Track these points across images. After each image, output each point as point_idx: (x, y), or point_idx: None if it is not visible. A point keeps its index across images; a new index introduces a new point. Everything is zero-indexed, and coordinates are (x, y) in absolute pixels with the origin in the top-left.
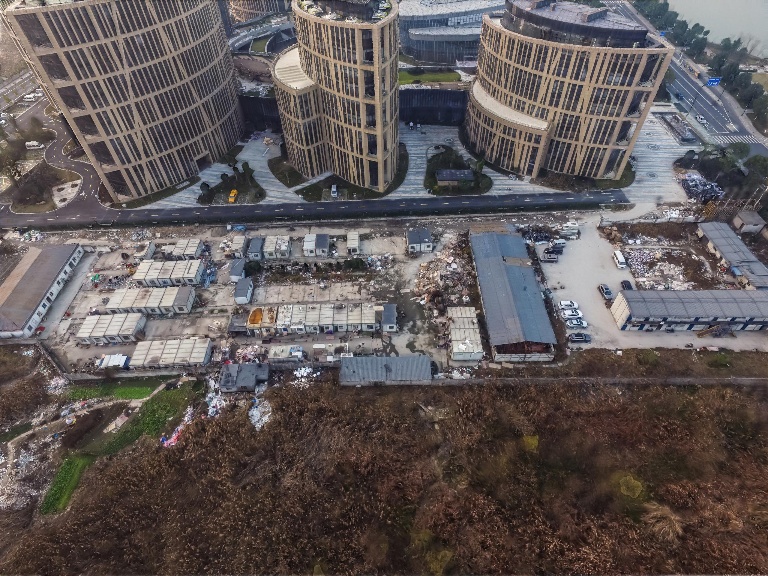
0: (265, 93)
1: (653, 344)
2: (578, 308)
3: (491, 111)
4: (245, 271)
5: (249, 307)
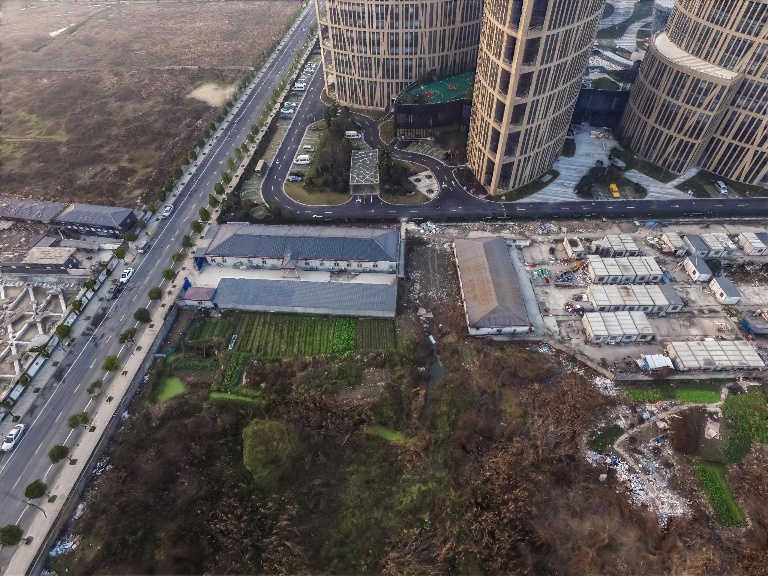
0: (591, 85)
1: None
2: None
3: None
4: None
5: (738, 308)
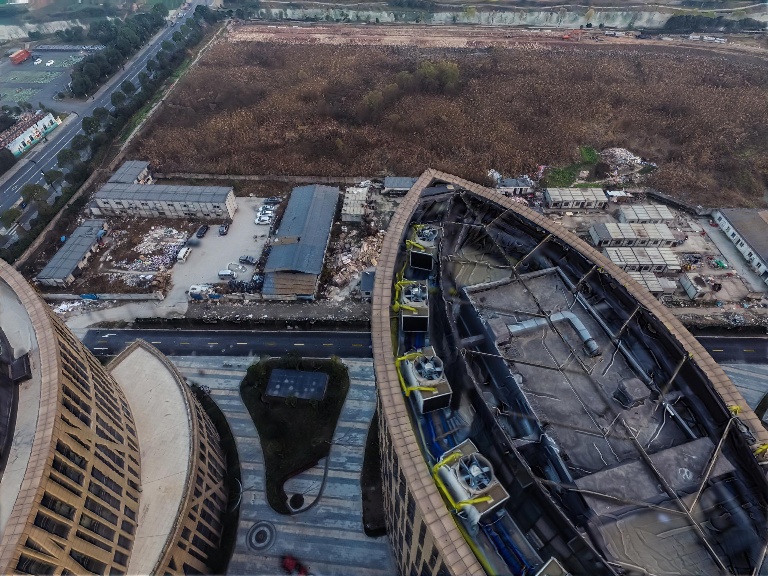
0: None
1: None
2: None
3: None
4: None
5: None
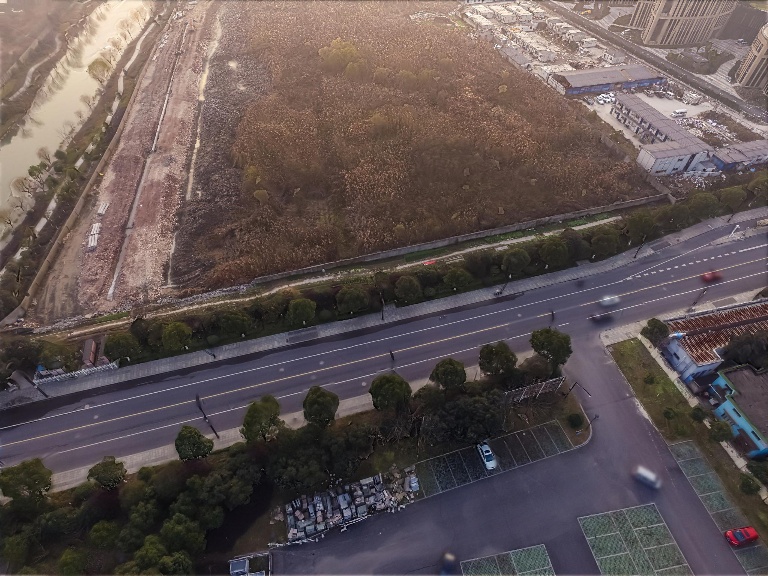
0: None
1: (609, 122)
2: None
3: (766, 24)
4: None
5: None
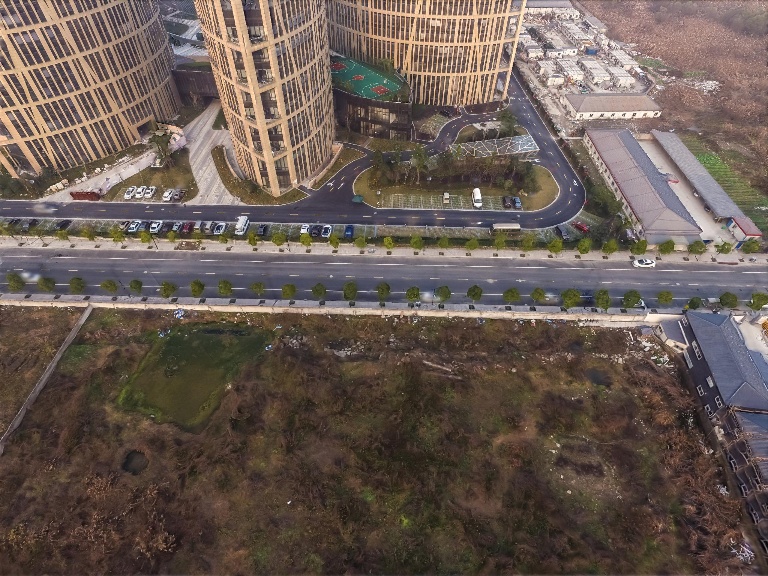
0: None
1: None
2: None
3: None
4: None
5: None
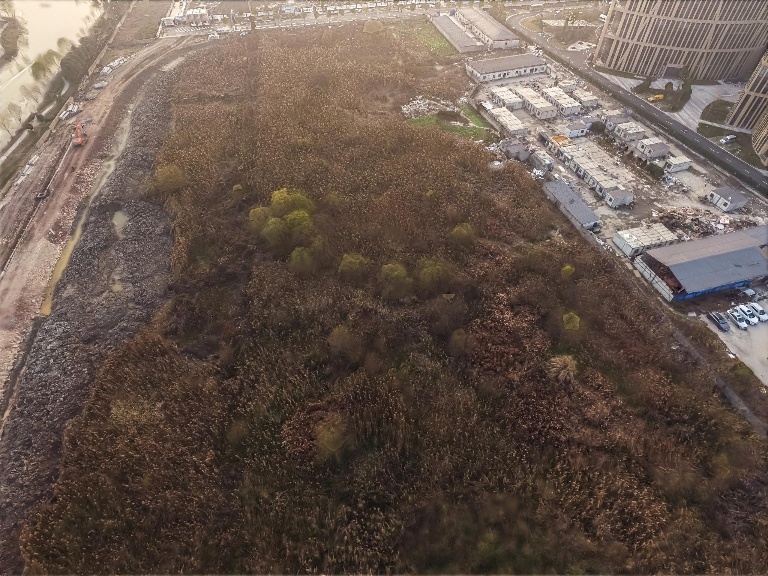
0: None
1: None
2: (763, 322)
3: None
4: (592, 125)
5: None
